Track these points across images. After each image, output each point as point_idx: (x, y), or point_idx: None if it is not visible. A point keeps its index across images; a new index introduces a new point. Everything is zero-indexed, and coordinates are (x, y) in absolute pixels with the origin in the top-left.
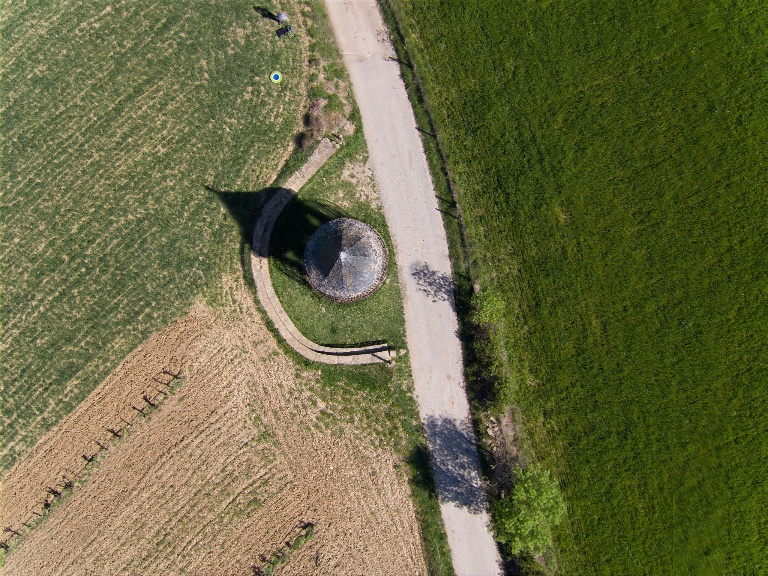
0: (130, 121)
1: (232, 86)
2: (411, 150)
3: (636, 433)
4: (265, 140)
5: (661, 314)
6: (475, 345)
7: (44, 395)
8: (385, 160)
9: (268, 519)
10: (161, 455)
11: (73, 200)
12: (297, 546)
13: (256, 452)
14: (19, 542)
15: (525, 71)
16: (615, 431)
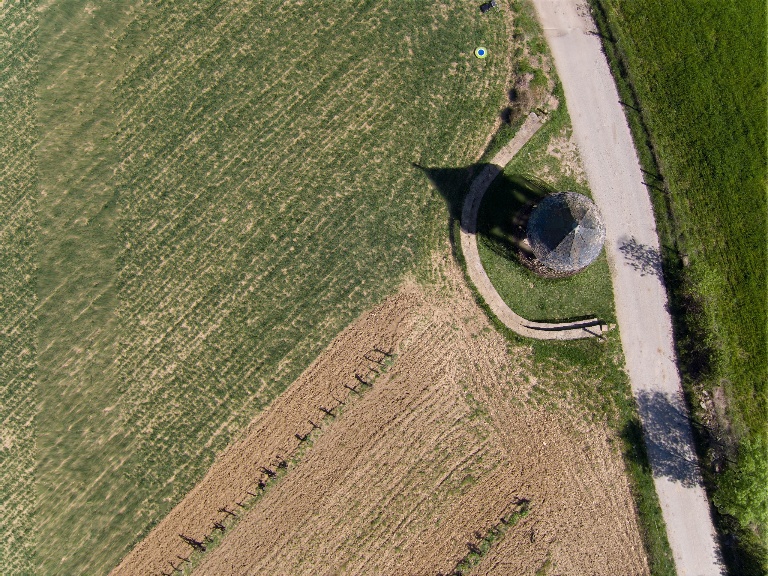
0: (335, 99)
1: (437, 62)
2: (615, 124)
3: None
4: (471, 116)
5: None
6: (688, 318)
7: (256, 375)
8: (589, 134)
9: (482, 496)
10: (374, 433)
11: (280, 179)
12: (512, 522)
13: (469, 429)
14: (234, 522)
15: (727, 43)
16: None
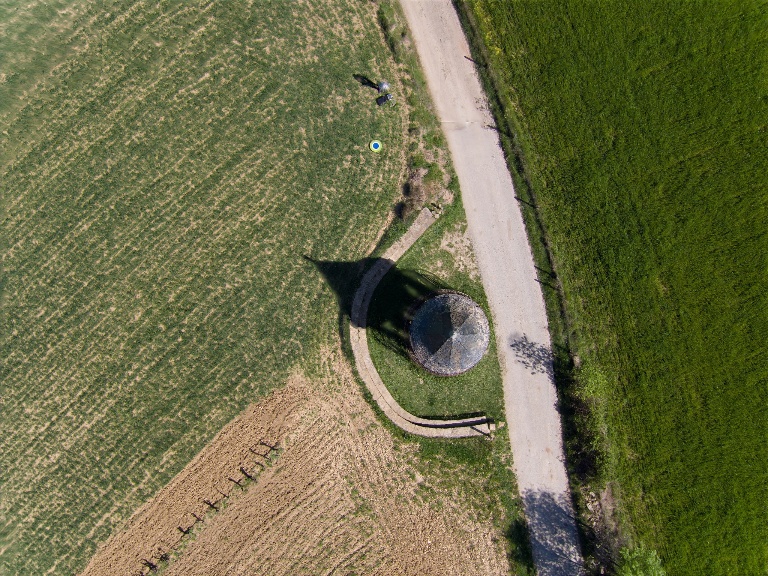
0: (228, 189)
1: (331, 155)
2: (510, 220)
3: (736, 508)
4: (364, 209)
5: (762, 388)
6: (576, 419)
7: (140, 466)
8: (484, 230)
9: None
10: (257, 527)
11: (170, 269)
12: None
13: (353, 525)
14: None
15: (625, 141)
16: (715, 506)
